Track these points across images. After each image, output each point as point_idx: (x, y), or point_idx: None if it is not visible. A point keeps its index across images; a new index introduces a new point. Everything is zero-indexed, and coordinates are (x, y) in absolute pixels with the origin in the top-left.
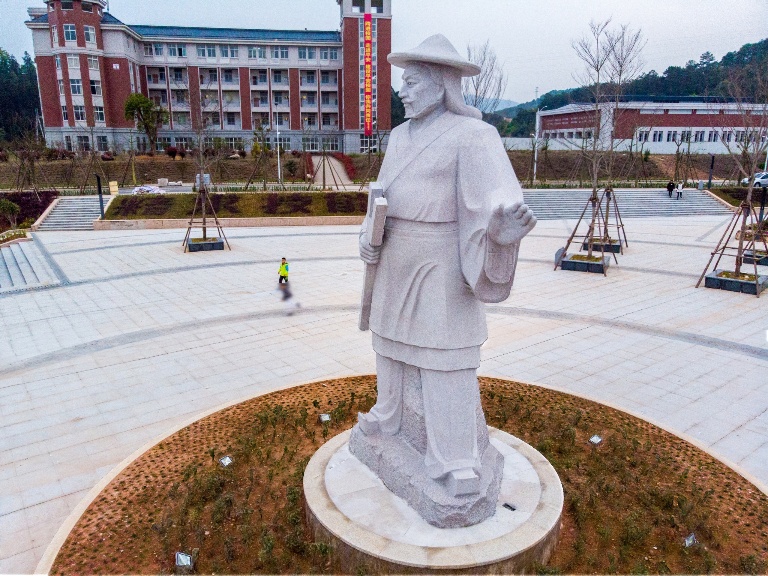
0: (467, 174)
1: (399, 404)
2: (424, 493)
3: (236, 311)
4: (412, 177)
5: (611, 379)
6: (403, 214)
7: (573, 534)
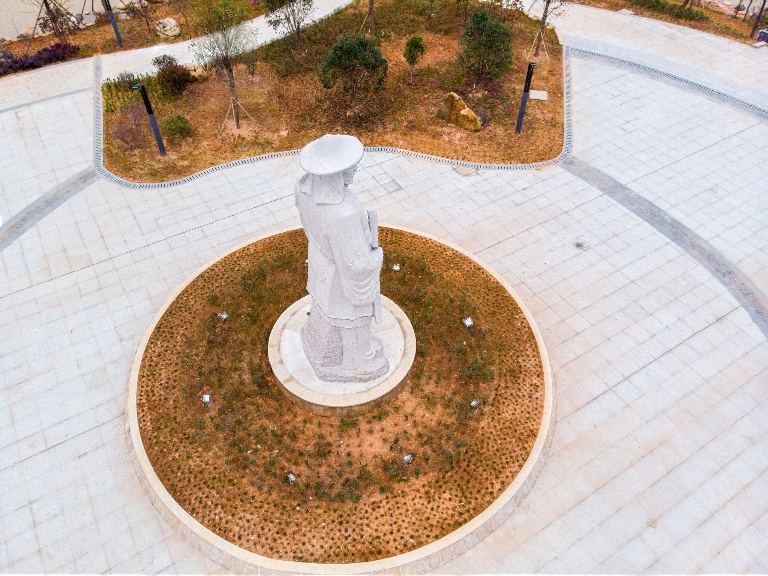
0: None
1: None
2: None
3: None
4: None
5: (69, 568)
6: None
7: None
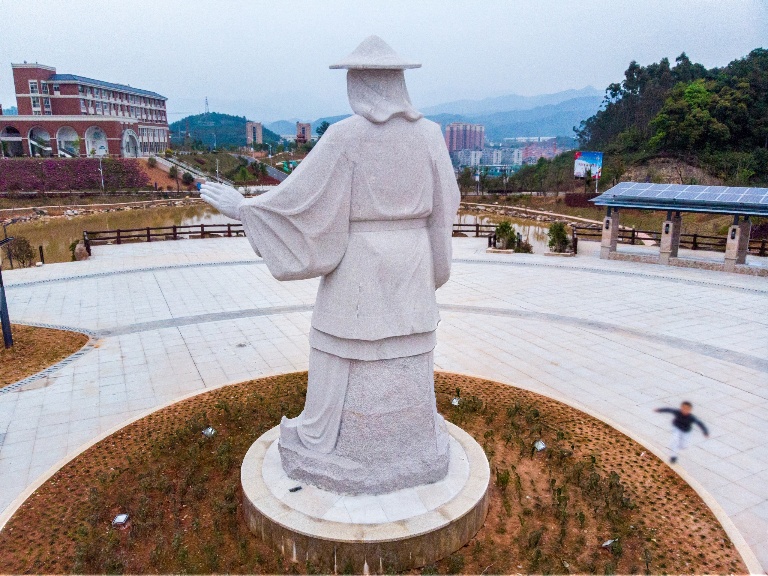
0: None
1: None
2: None
3: None
4: None
5: None
6: None
7: None
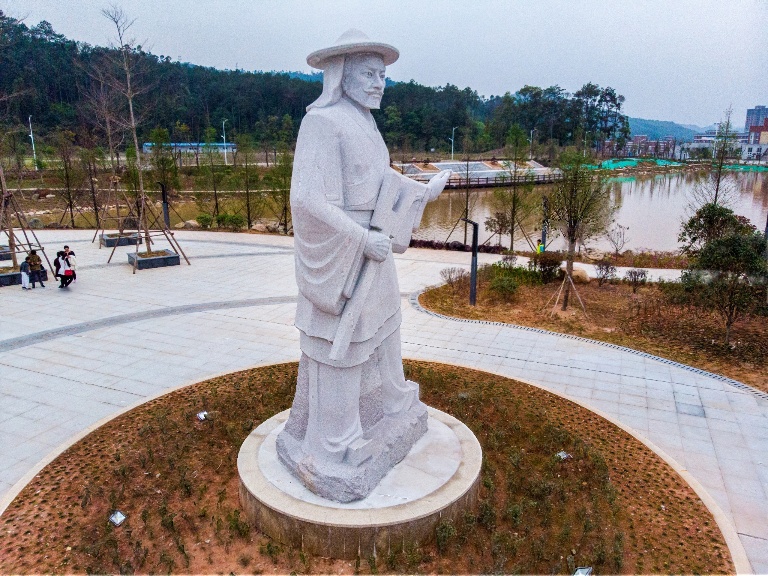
0: None
1: None
2: None
3: None
4: None
5: None
6: None
7: None
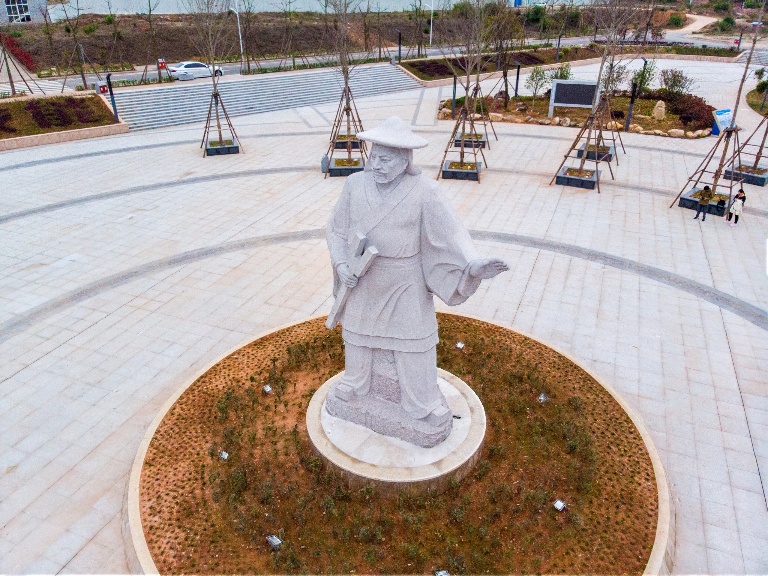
0: (430, 221)
1: (369, 374)
2: (417, 431)
3: (53, 293)
4: (390, 227)
5: None
6: (385, 254)
7: (486, 417)
